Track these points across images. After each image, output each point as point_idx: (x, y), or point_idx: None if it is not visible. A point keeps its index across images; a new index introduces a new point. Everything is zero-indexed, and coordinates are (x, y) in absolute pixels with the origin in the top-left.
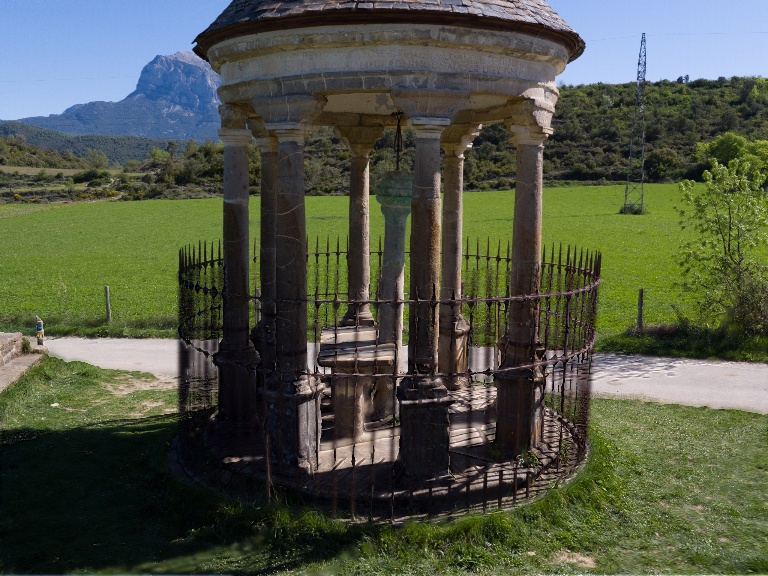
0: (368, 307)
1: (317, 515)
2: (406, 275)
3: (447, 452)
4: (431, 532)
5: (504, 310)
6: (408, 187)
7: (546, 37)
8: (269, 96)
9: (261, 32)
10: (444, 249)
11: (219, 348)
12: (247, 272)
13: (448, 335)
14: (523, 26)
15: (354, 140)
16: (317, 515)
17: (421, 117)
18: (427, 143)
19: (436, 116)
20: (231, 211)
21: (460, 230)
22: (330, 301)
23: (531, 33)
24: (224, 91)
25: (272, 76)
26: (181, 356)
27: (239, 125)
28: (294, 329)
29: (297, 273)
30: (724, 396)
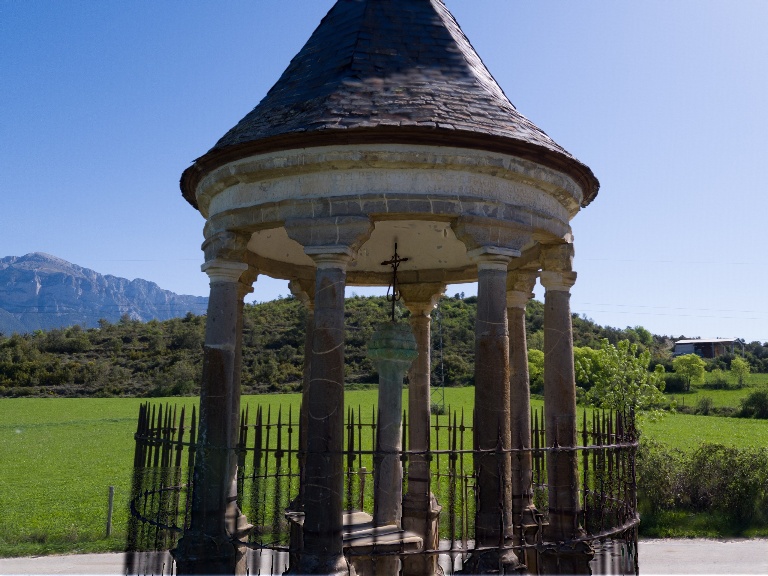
0: None
1: None
2: (247, 474)
3: None
4: None
5: (473, 486)
6: (410, 339)
7: (581, 185)
8: (310, 217)
9: (312, 146)
10: (414, 416)
11: (187, 541)
12: (229, 436)
13: (422, 517)
14: (573, 169)
15: None
16: None
17: (494, 246)
18: (497, 275)
19: (507, 247)
20: (217, 358)
21: None
22: (423, 452)
23: (575, 178)
24: (231, 215)
25: (316, 195)
26: None
27: (236, 257)
28: (334, 500)
29: (338, 426)
30: (686, 572)
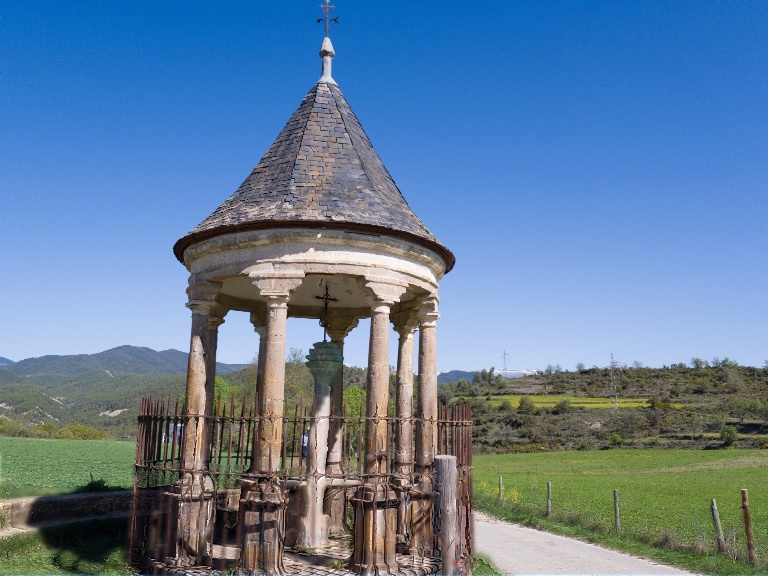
0: (410, 470)
1: (117, 553)
2: None
3: (177, 539)
4: (112, 575)
5: None
6: None
7: (248, 230)
8: None
9: None
10: None
11: None
12: None
13: None
14: (222, 230)
15: (397, 324)
16: (117, 553)
17: None
18: None
19: None
20: None
21: (427, 393)
22: None
23: (231, 232)
24: None
25: None
26: (497, 538)
27: (260, 325)
28: None
29: None
30: None
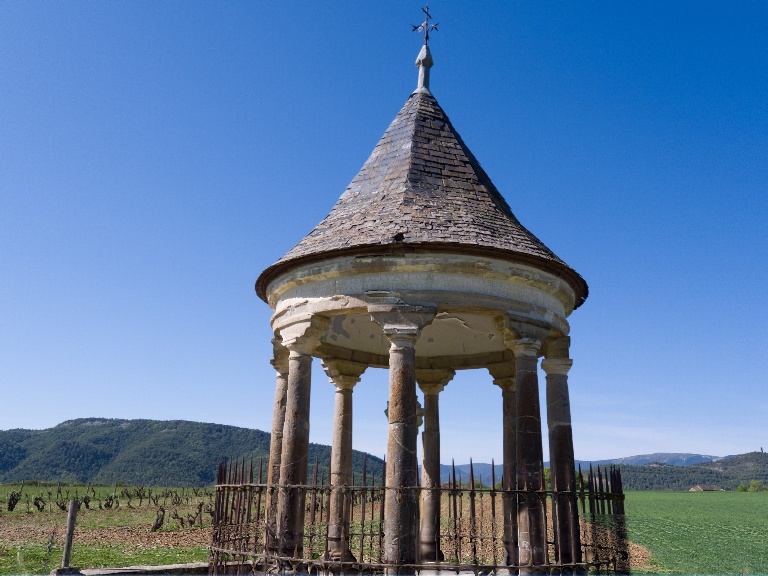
0: None
1: None
2: None
3: None
4: None
5: None
6: None
7: None
8: None
9: None
10: None
11: None
12: None
13: None
14: None
15: None
16: None
17: None
18: None
19: None
20: None
21: None
22: None
23: None
24: None
25: None
26: None
27: None
28: None
29: None
30: None
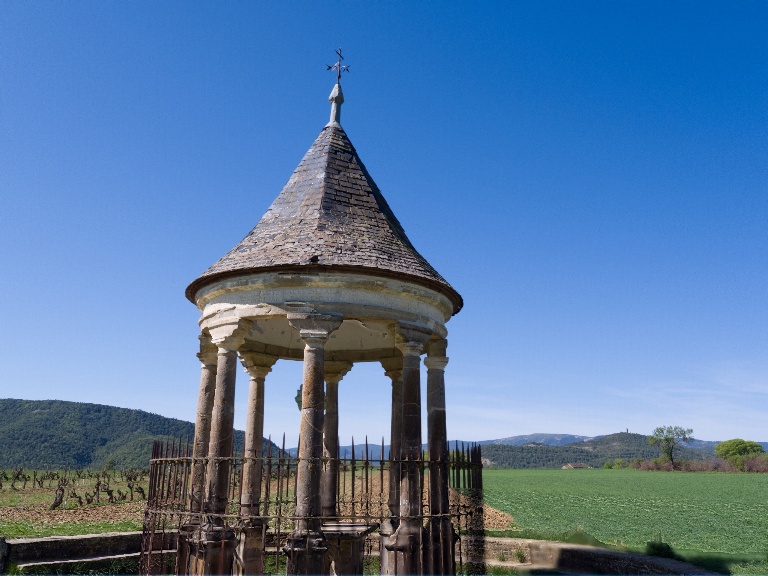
0: None
1: None
2: None
3: None
4: None
5: None
6: None
7: None
8: None
9: None
10: None
11: None
12: None
13: None
14: None
15: None
16: None
17: None
18: None
19: None
20: None
21: None
22: None
23: None
24: None
25: None
26: None
27: None
28: None
29: None
30: None
